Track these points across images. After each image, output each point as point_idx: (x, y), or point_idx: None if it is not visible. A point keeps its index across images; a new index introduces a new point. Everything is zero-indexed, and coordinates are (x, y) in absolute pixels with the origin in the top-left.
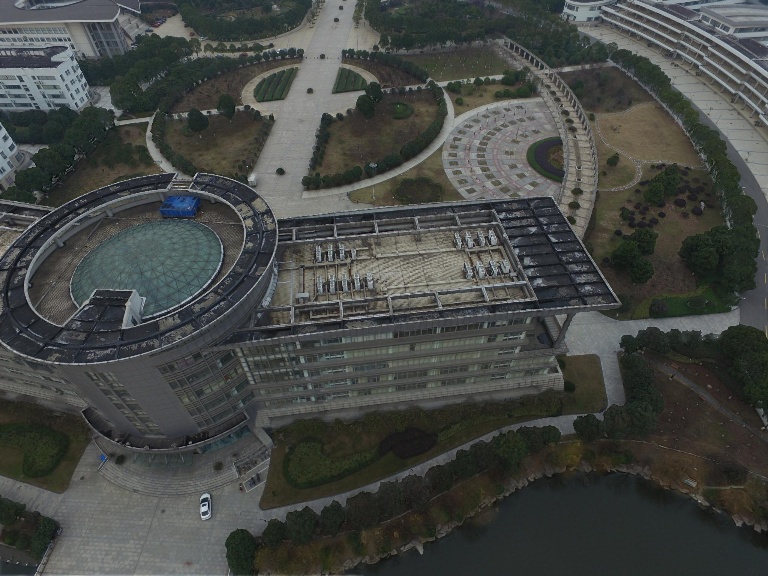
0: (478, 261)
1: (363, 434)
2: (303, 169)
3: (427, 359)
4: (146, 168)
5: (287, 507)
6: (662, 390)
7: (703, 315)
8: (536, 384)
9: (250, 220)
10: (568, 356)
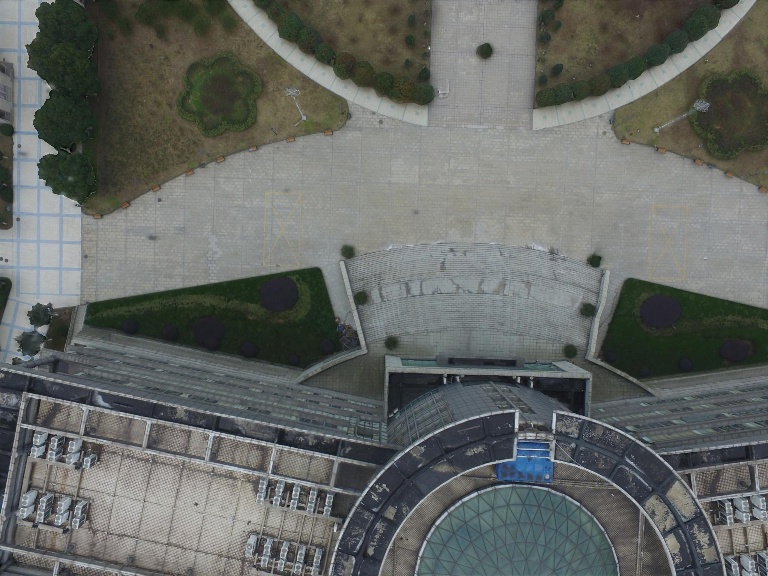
0: None
1: None
2: (524, 39)
3: None
4: (227, 35)
5: None
6: None
7: None
8: None
9: (674, 538)
10: None
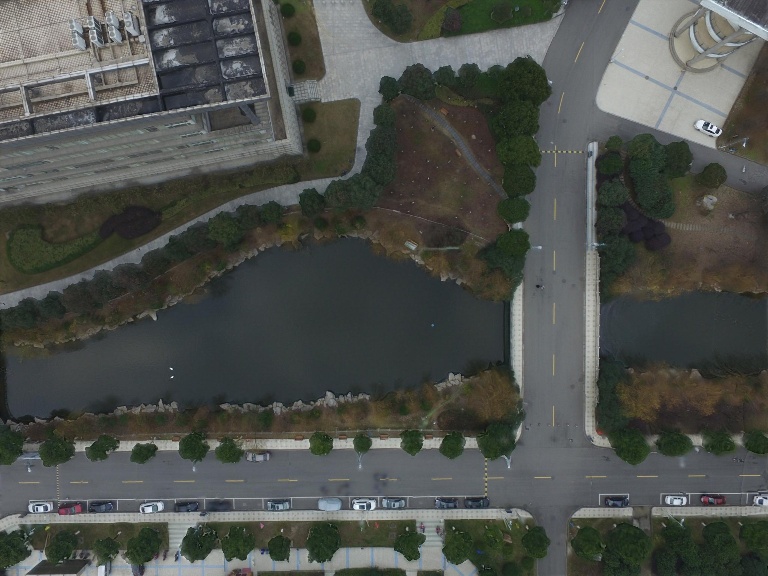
0: (87, 17)
1: (85, 215)
2: None
3: (91, 151)
4: None
5: (21, 291)
6: (419, 144)
7: (512, 28)
8: (263, 152)
9: None
10: (323, 103)
